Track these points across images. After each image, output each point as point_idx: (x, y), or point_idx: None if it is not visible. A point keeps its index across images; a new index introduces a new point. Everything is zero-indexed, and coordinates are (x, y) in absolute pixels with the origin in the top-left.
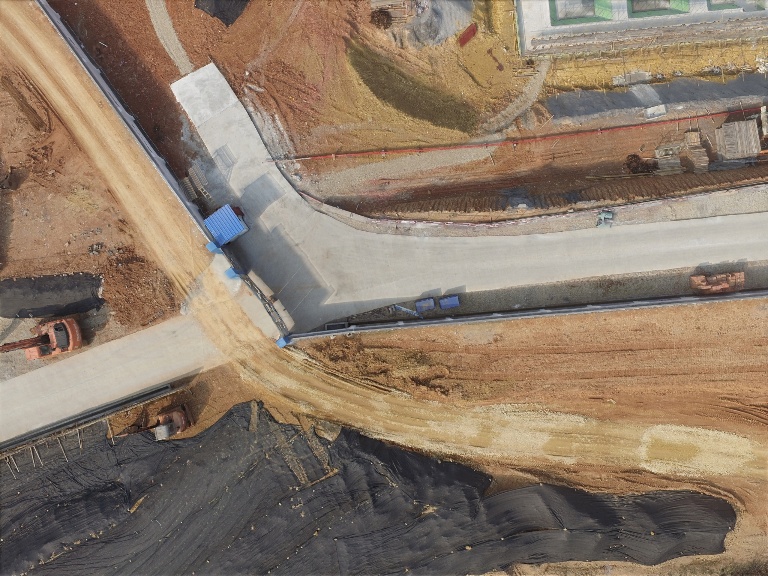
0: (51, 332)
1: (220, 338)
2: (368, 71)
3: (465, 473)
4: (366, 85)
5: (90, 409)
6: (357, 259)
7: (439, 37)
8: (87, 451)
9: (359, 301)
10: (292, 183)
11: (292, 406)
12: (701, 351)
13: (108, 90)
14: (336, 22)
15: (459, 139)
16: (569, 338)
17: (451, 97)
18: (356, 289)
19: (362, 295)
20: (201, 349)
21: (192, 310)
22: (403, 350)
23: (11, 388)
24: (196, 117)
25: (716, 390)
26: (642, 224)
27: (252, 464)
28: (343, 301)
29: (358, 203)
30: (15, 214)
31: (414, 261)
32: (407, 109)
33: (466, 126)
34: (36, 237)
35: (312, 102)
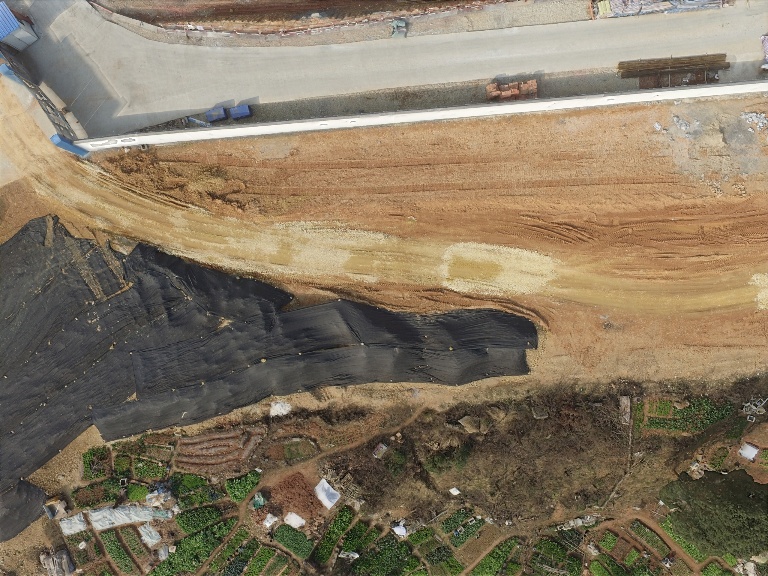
0: None
1: (14, 152)
2: None
3: (263, 289)
4: None
5: None
6: (149, 70)
7: None
8: None
9: (152, 113)
10: None
11: (88, 221)
12: (500, 165)
13: None
14: None
15: None
16: (367, 152)
17: None
18: (149, 101)
19: (155, 107)
20: None
21: None
22: (199, 165)
23: None
24: None
25: (517, 207)
26: (438, 35)
27: (48, 279)
28: (136, 113)
29: (154, 17)
30: None
31: (206, 72)
32: None
33: None
34: None
35: None
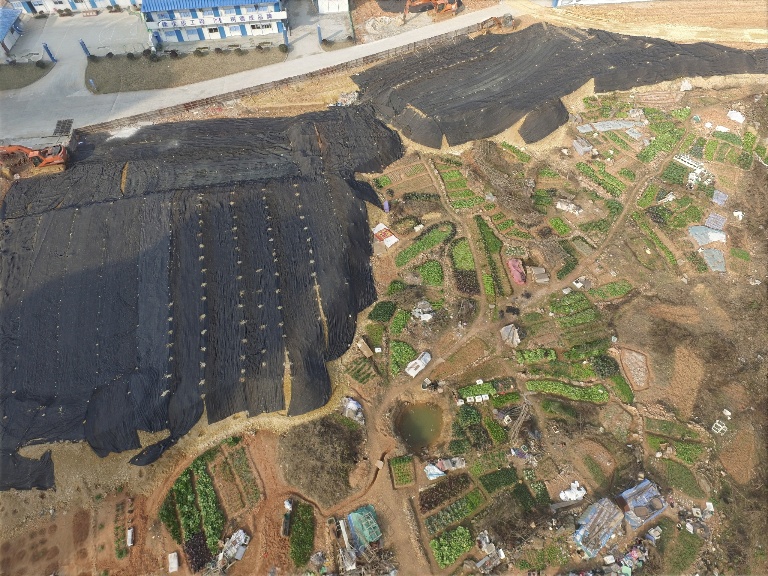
0: None
1: (520, 8)
2: None
3: None
4: None
5: None
6: None
7: None
8: None
9: None
10: None
11: (562, 23)
12: (752, 7)
13: None
14: None
15: None
16: (686, 5)
17: None
18: None
19: None
20: None
21: (505, 2)
22: None
23: (415, 32)
24: None
25: None
26: None
27: None
28: None
29: None
30: None
31: None
32: None
33: None
34: None
35: None
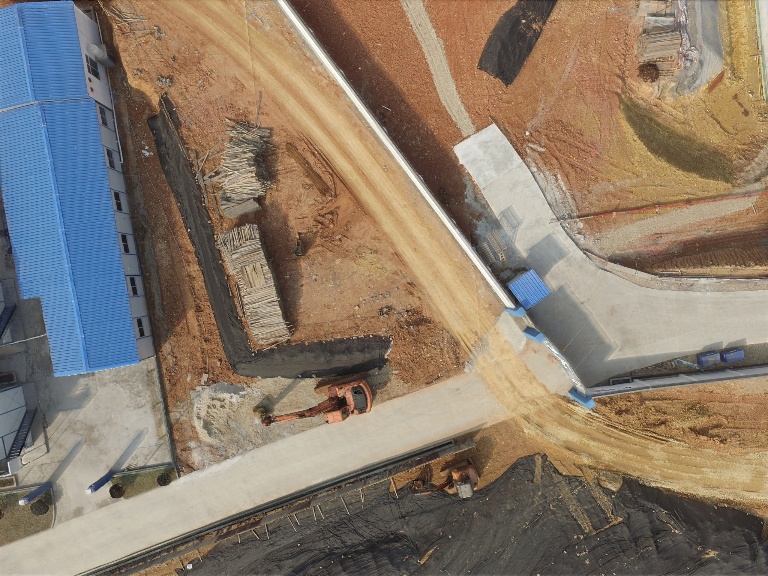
0: (348, 395)
1: (504, 394)
2: (637, 126)
3: (741, 518)
4: (640, 141)
5: (371, 464)
6: (641, 315)
7: (694, 86)
8: (369, 504)
9: (642, 356)
10: (575, 242)
11: (575, 458)
12: None
13: (395, 155)
14: (608, 78)
15: (723, 190)
16: None
17: (702, 145)
18: (639, 344)
19: (645, 350)
20: (485, 405)
21: (476, 368)
22: (682, 401)
23: (291, 445)
24: (481, 179)
25: None
26: None
27: (537, 515)
28: (626, 356)
29: (635, 259)
30: (304, 279)
31: (696, 316)
32: (675, 162)
33: (726, 176)
34: (326, 301)
35: (591, 160)
